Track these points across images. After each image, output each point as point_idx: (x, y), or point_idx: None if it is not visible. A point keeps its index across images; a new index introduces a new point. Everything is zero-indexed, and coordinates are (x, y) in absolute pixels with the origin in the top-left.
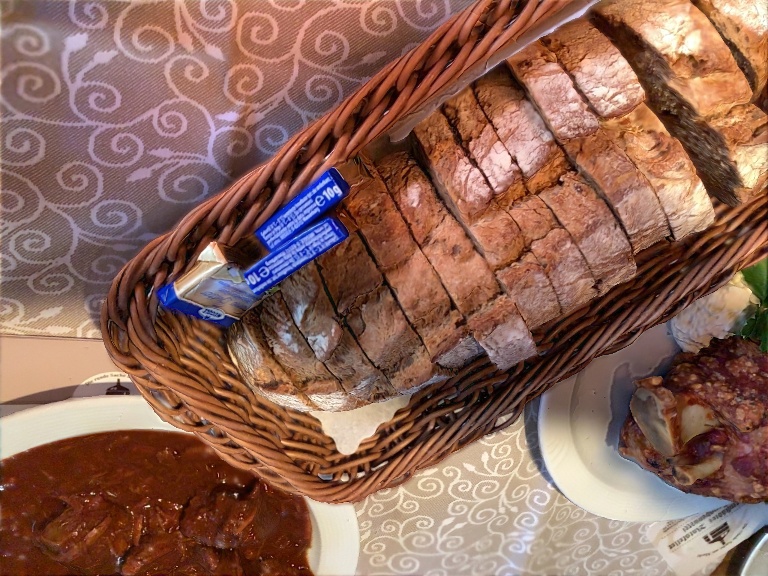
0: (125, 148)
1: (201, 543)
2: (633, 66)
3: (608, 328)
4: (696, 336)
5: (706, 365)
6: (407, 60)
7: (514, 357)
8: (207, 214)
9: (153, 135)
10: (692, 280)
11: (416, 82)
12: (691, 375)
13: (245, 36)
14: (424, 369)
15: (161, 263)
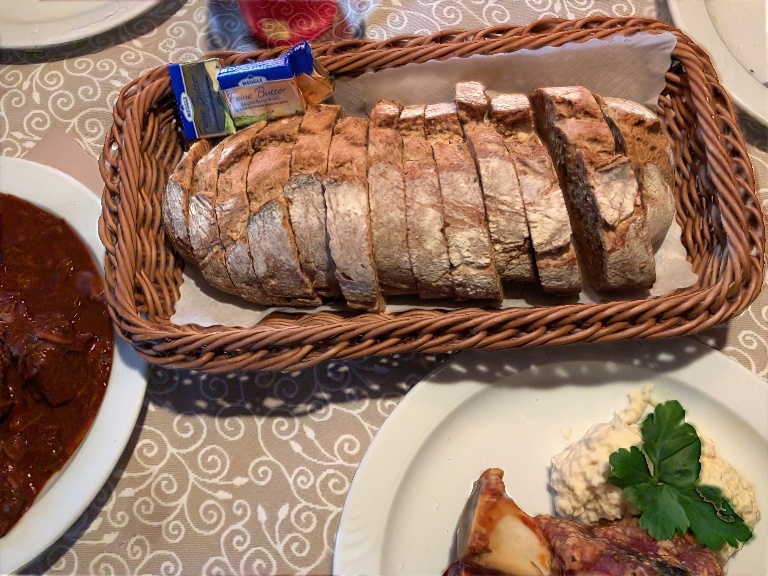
0: None
1: (4, 356)
2: (543, 130)
3: None
4: (568, 473)
5: None
6: None
7: (347, 241)
8: (233, 54)
9: None
10: (546, 309)
11: None
12: None
13: None
14: None
15: None
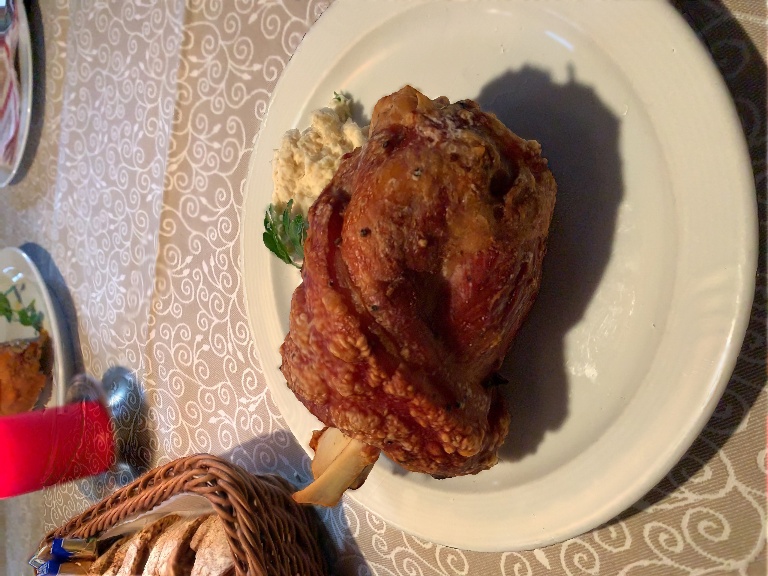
0: None
1: None
2: None
3: None
4: None
5: None
6: None
7: None
8: (54, 532)
9: None
10: None
11: None
12: None
13: (142, 455)
14: None
15: None
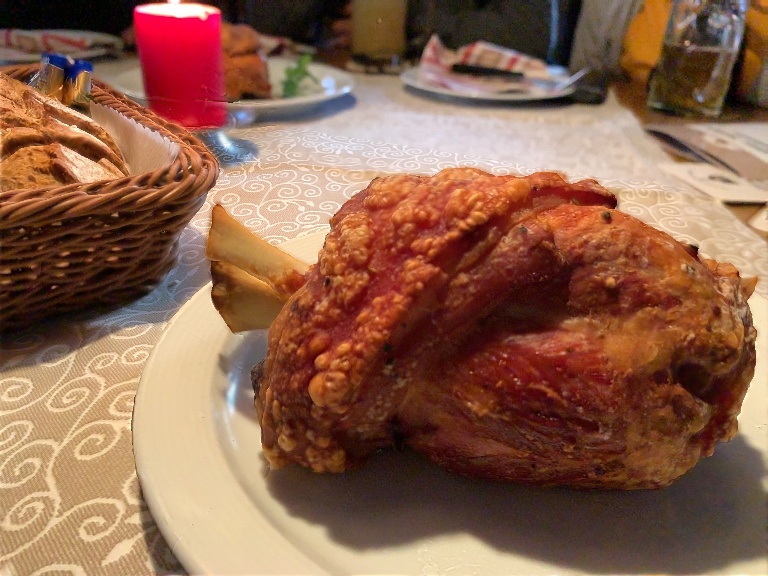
0: None
1: None
2: None
3: None
4: None
5: None
6: None
7: None
8: None
9: None
10: None
11: None
12: None
13: None
14: None
15: None
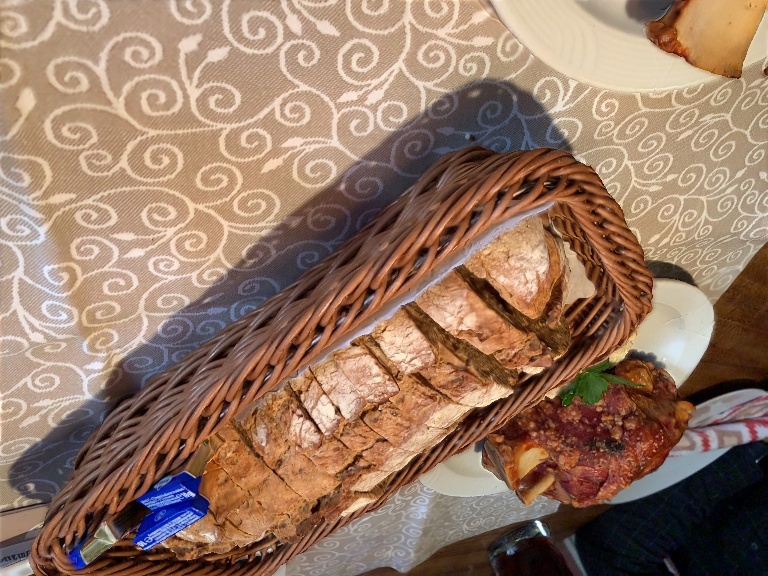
0: (10, 408)
1: None
2: None
3: (445, 448)
4: None
5: (543, 411)
6: (229, 386)
7: None
8: (93, 504)
9: (32, 394)
10: (507, 411)
11: (242, 392)
12: (530, 423)
13: (91, 319)
14: (294, 533)
15: (66, 532)
